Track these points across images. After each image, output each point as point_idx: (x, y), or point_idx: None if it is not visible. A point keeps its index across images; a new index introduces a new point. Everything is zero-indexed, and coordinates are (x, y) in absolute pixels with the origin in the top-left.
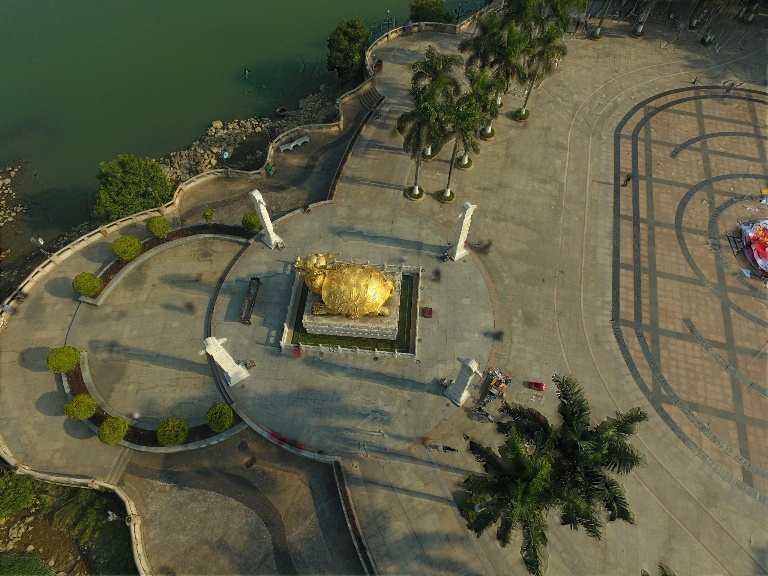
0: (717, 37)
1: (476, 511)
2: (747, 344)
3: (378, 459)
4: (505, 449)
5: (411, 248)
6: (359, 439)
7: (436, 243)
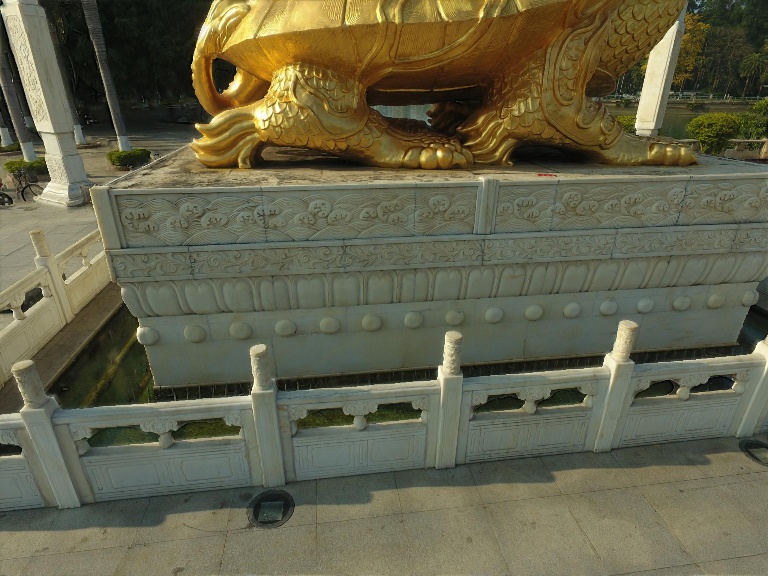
0: None
1: (132, 150)
2: None
3: None
4: None
5: None
6: None
7: None
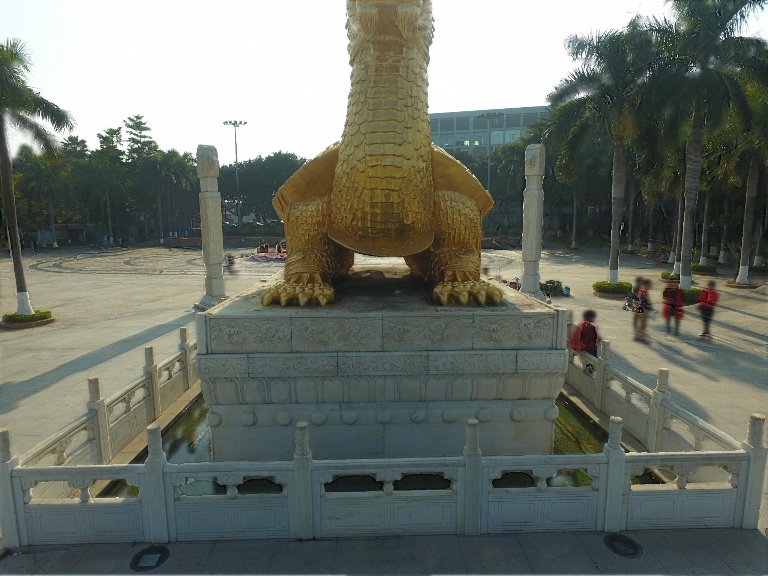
0: (0, 240)
1: None
2: (374, 263)
3: (763, 334)
4: (660, 82)
5: (170, 330)
6: (767, 348)
7: (175, 317)
